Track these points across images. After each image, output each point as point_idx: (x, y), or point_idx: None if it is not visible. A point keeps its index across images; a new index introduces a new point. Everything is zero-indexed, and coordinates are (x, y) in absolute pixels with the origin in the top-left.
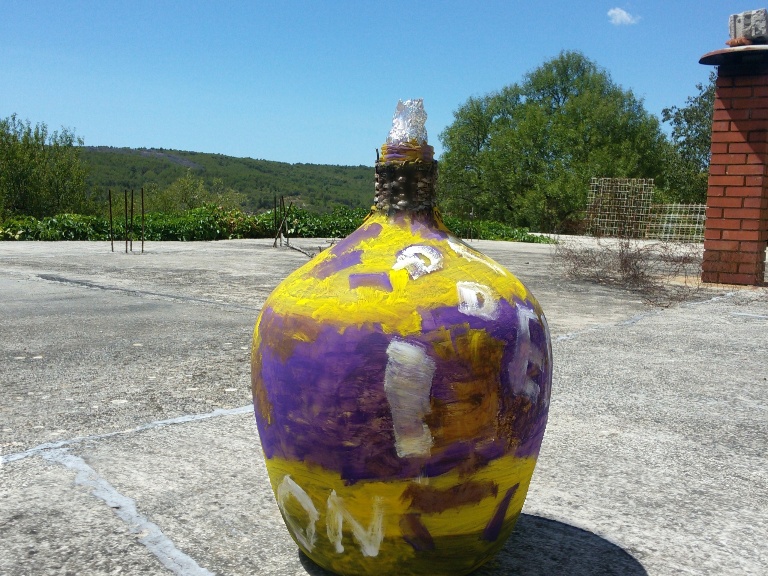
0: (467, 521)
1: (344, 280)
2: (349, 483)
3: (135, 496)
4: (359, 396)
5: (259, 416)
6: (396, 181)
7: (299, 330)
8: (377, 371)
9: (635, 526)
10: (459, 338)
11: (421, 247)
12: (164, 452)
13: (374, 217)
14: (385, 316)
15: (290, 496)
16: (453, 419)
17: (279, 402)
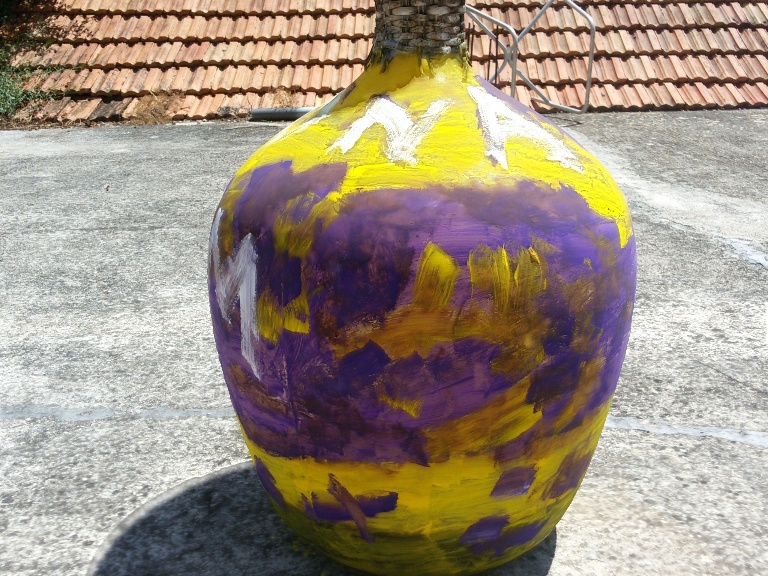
0: None
1: None
2: None
3: None
4: None
5: None
6: None
7: None
8: None
9: None
10: None
11: None
12: None
13: None
14: None
15: None
16: None
17: None
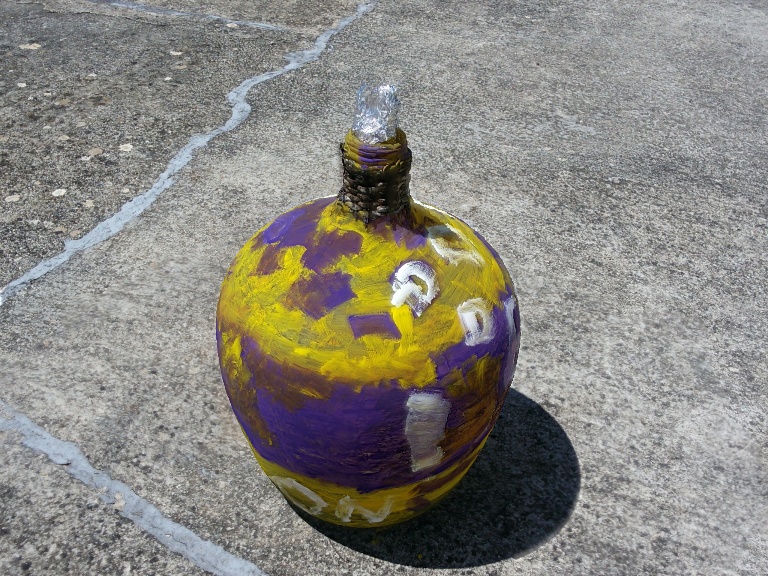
0: (456, 480)
1: (345, 324)
2: (364, 492)
3: (73, 437)
4: (380, 441)
5: (252, 430)
6: (376, 187)
7: (308, 385)
8: (398, 422)
9: (538, 366)
10: (469, 373)
11: (412, 264)
12: (56, 343)
13: (347, 218)
14: (401, 370)
15: (293, 489)
16: (462, 435)
17: (287, 438)
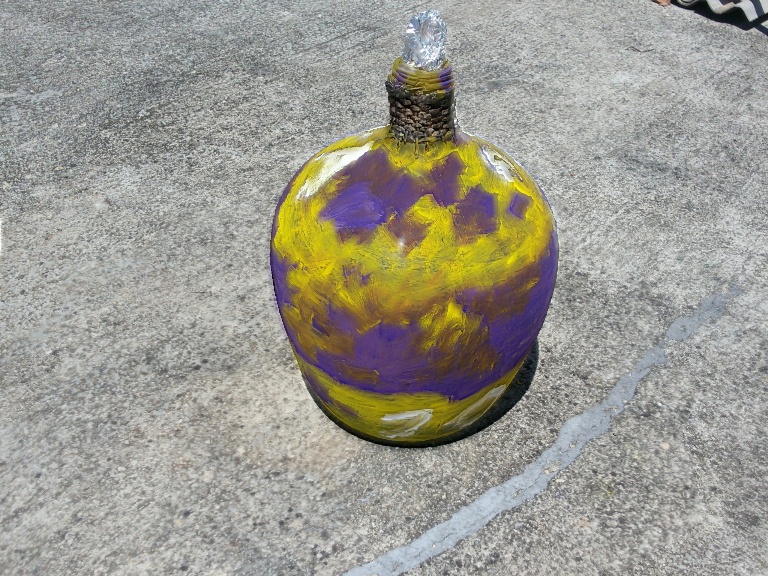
0: None
1: None
2: None
3: None
4: None
5: None
6: None
7: (530, 279)
8: None
9: None
10: None
11: (485, 150)
12: None
13: (438, 147)
14: None
15: None
16: None
17: None
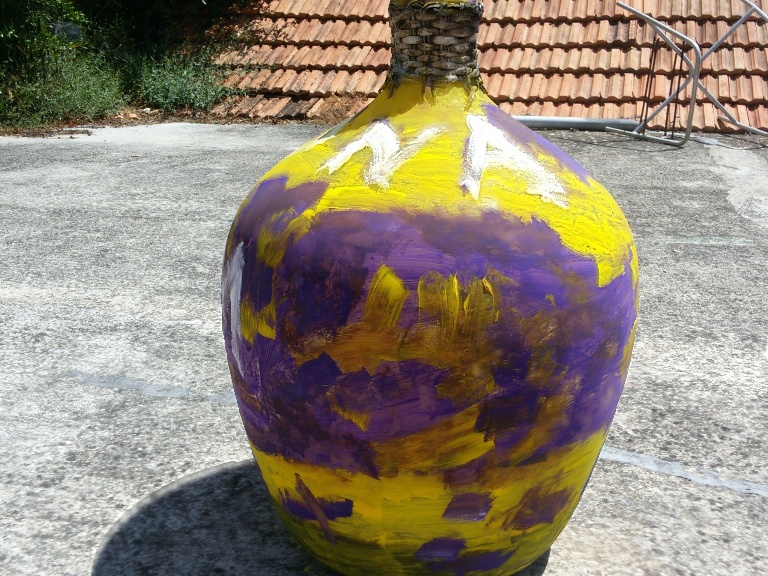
0: None
1: None
2: None
3: None
4: None
5: None
6: None
7: None
8: None
9: None
10: None
11: None
12: None
13: None
14: None
15: None
16: None
17: None
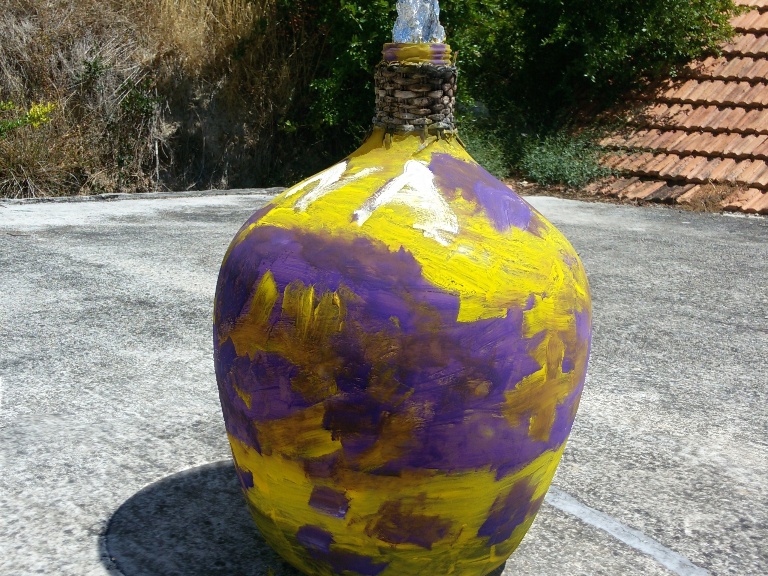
0: None
1: None
2: None
3: None
4: None
5: None
6: None
7: None
8: None
9: (30, 571)
10: None
11: None
12: None
13: None
14: None
15: None
16: None
17: None
